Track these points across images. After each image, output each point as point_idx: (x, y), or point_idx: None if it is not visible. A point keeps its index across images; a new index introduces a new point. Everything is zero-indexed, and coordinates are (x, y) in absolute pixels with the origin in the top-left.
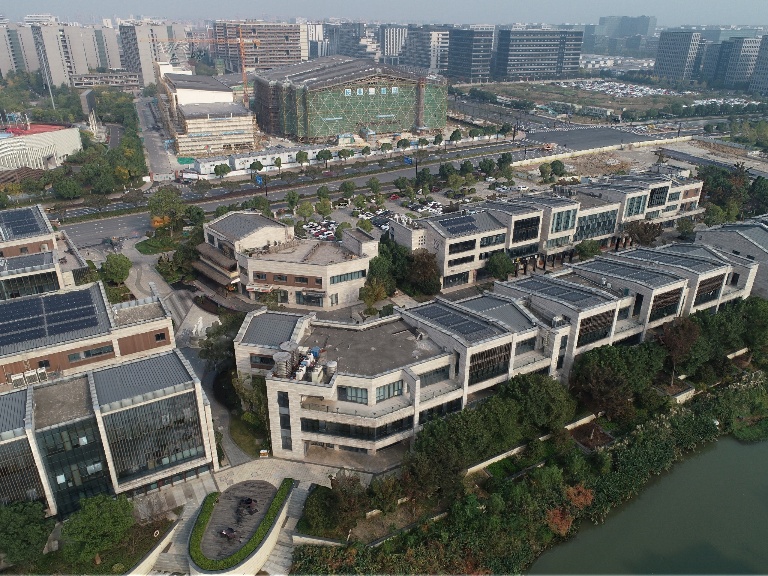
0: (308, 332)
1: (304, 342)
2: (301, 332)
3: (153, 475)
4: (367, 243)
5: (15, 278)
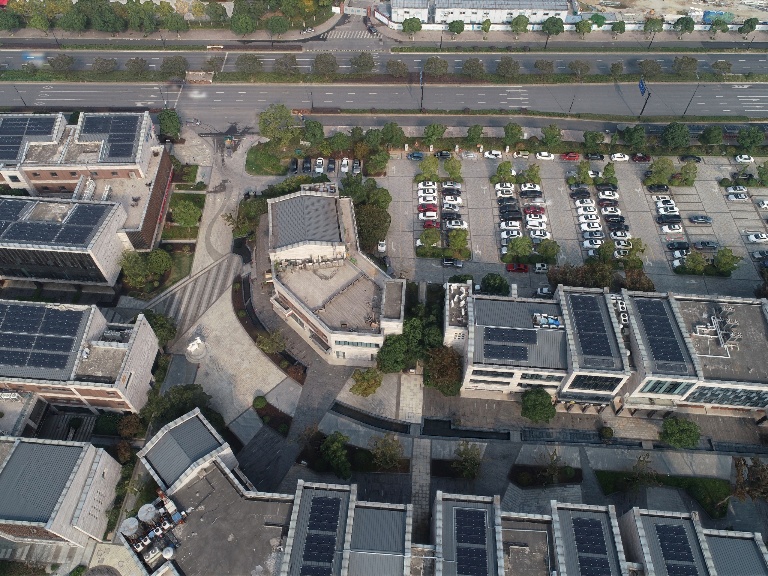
0: (200, 475)
1: (189, 487)
2: (192, 475)
3: (39, 541)
4: (388, 321)
5: (58, 252)
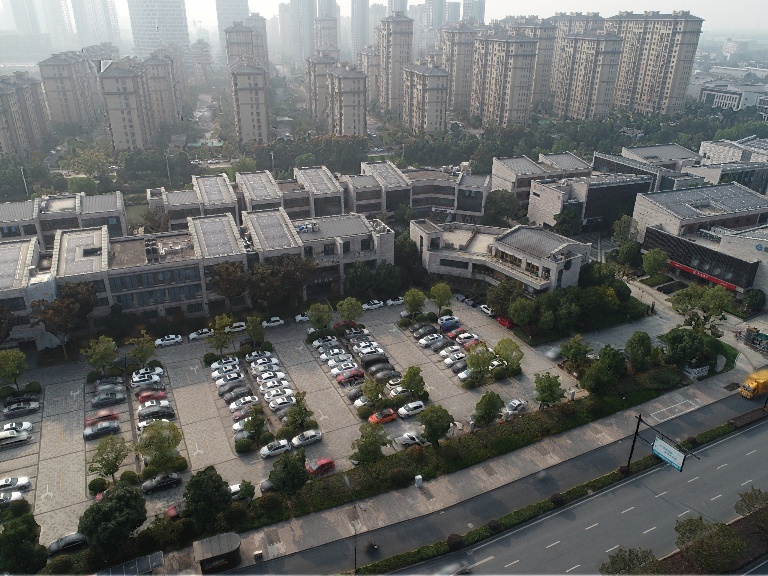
0: None
1: None
2: None
3: None
4: (421, 221)
5: None
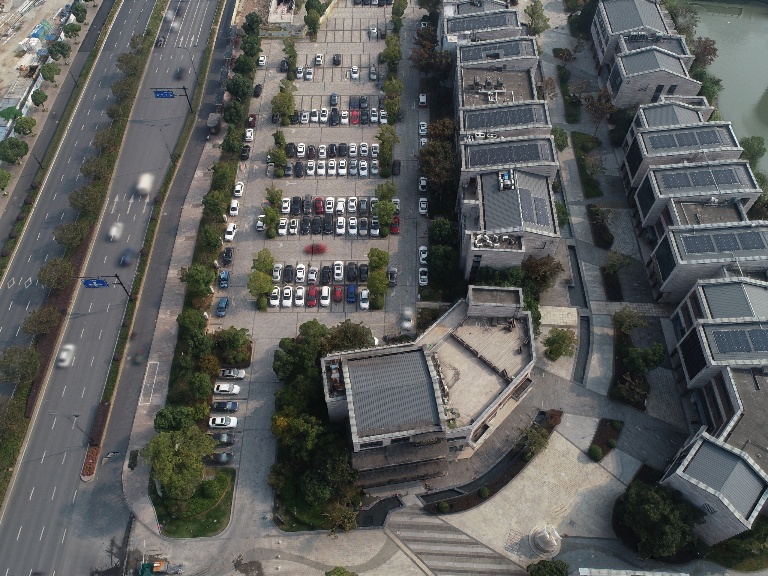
0: None
1: None
2: None
3: None
4: None
5: None
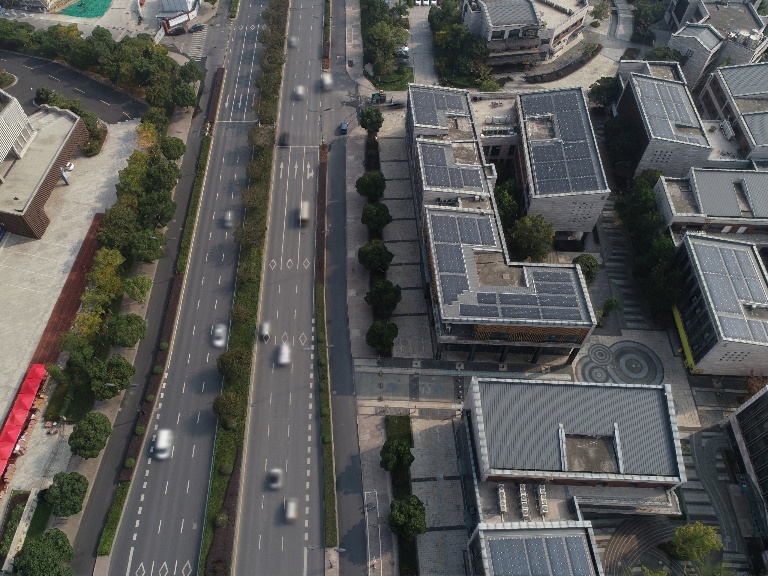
0: None
1: None
2: None
3: None
4: None
5: None
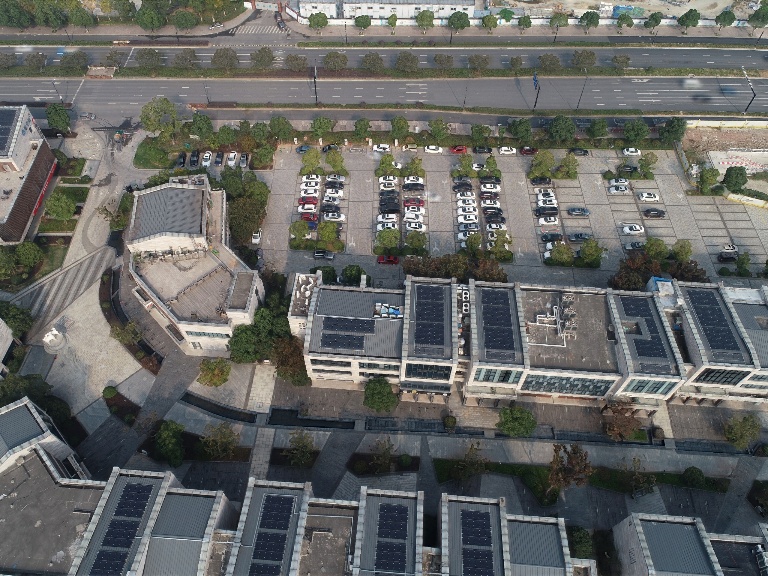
0: (18, 463)
1: (5, 474)
2: (8, 463)
3: None
4: (233, 312)
5: None
